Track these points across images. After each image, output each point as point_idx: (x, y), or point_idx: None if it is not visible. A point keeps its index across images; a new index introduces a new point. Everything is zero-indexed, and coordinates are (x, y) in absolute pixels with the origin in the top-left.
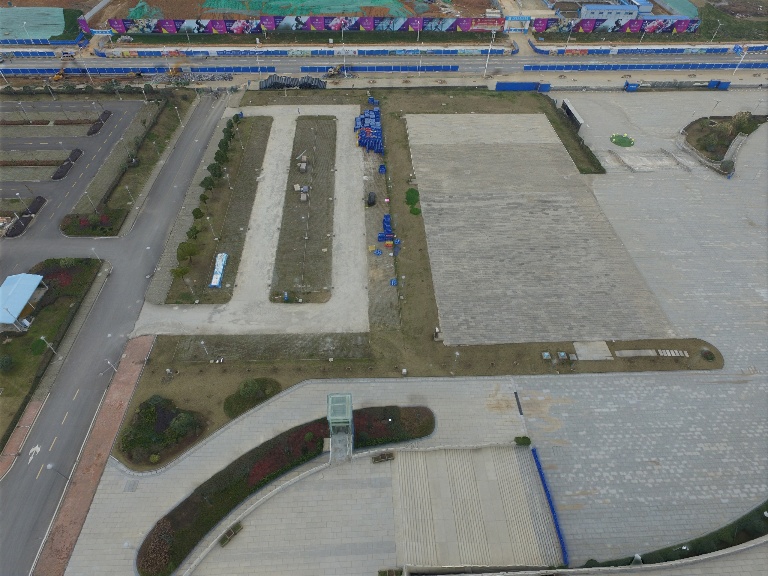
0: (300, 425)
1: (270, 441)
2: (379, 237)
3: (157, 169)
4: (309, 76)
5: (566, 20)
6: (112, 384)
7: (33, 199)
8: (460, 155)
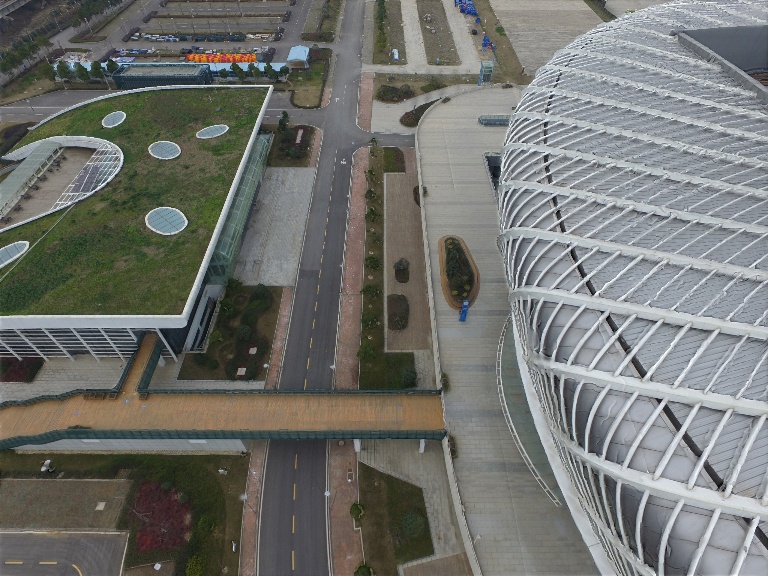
0: None
1: None
2: (483, 43)
3: (340, 20)
4: None
5: None
6: (361, 84)
7: (277, 29)
8: (527, 14)
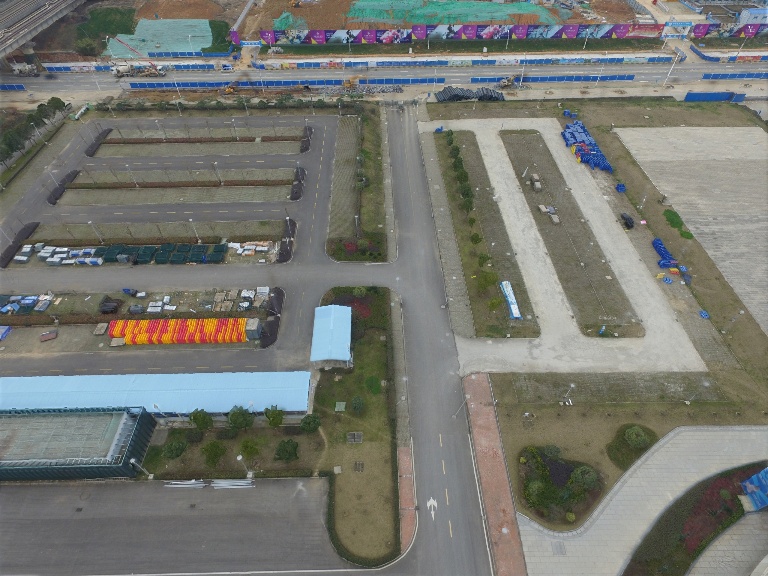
0: (706, 480)
1: (686, 499)
2: (663, 264)
3: (388, 188)
4: (480, 87)
5: (729, 25)
6: (473, 428)
7: (282, 221)
8: (697, 172)
